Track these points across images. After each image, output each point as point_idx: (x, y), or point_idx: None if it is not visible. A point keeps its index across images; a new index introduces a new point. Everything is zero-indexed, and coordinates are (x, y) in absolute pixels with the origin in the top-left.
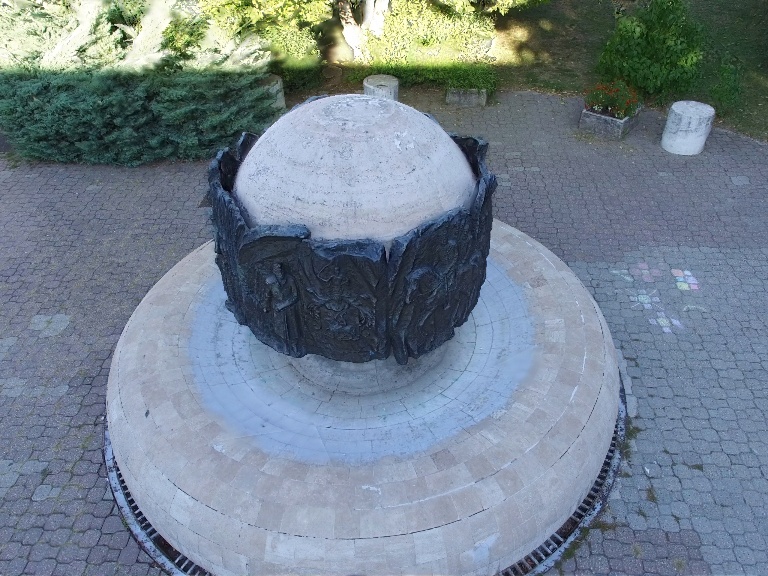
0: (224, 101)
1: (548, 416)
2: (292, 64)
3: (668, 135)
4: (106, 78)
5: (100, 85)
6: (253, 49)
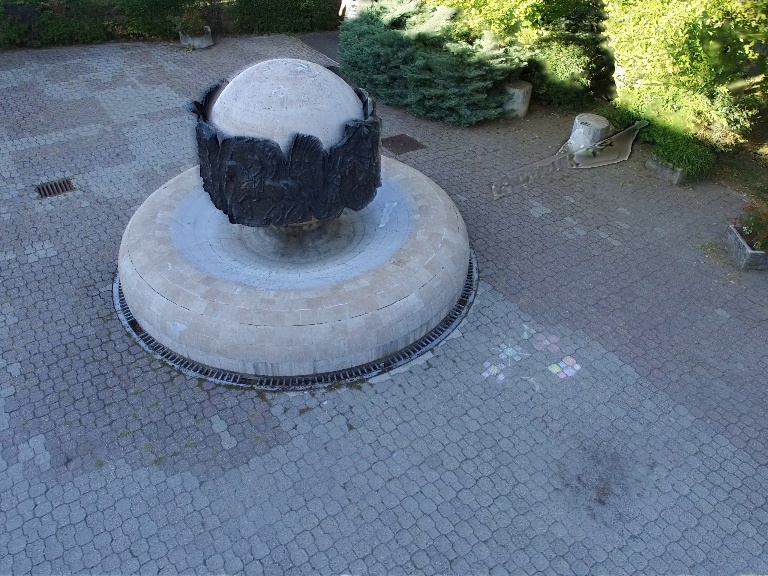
0: (459, 84)
1: (273, 305)
2: (554, 82)
3: None
4: (393, 37)
5: (380, 39)
6: (495, 53)
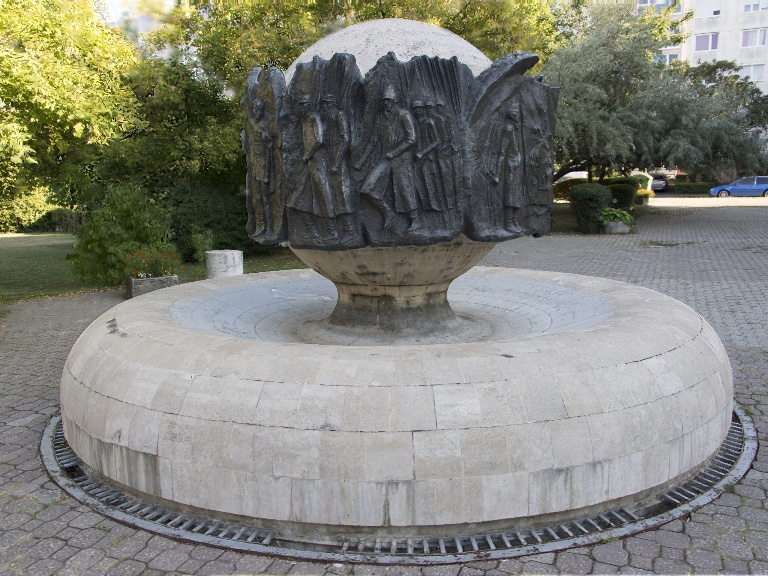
0: None
1: None
2: None
3: None
4: None
5: None
6: None
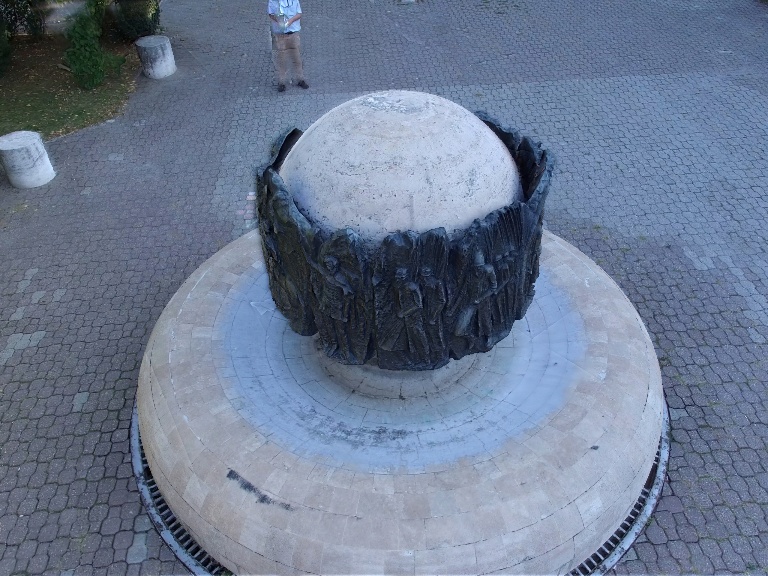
0: None
1: None
2: None
3: (27, 173)
4: None
5: None
6: None
